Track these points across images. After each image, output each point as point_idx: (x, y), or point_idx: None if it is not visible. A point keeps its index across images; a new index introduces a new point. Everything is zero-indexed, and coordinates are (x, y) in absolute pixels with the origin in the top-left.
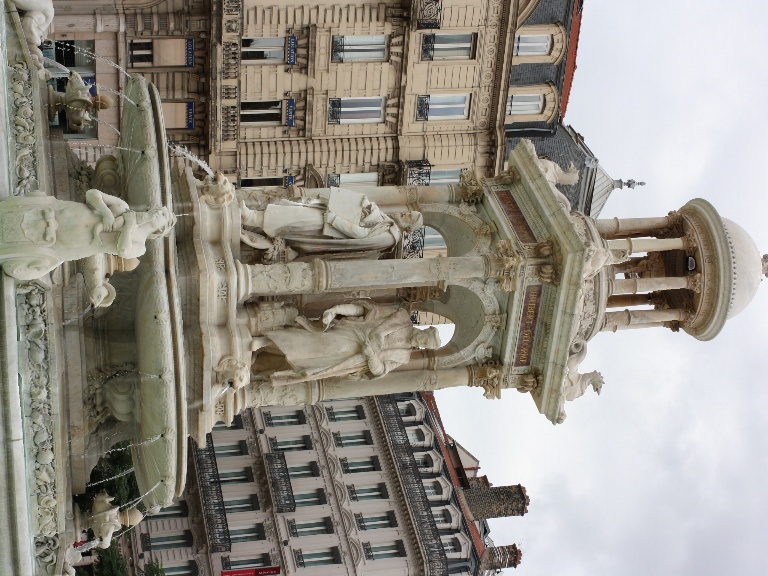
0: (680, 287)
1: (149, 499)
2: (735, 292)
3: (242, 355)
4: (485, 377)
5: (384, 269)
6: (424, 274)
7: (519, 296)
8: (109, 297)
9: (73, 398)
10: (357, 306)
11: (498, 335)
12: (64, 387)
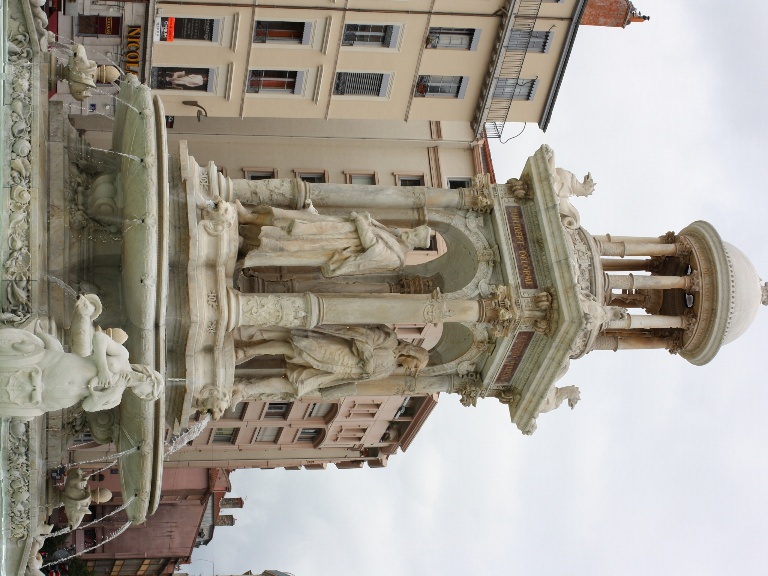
0: (669, 248)
1: None
2: (727, 251)
3: None
4: (495, 299)
5: None
6: (399, 189)
7: (501, 216)
8: None
9: (54, 177)
10: None
11: (497, 273)
12: (46, 162)
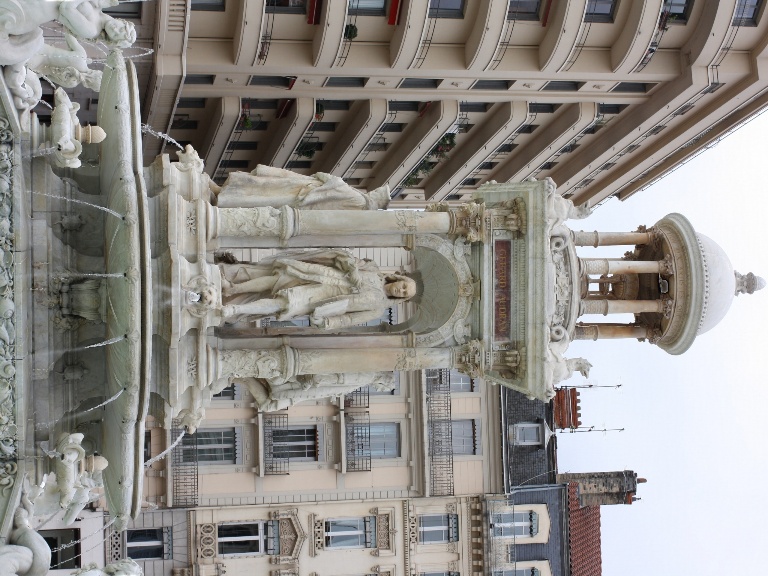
0: None
1: None
2: None
3: None
4: None
5: None
6: None
7: None
8: None
9: None
10: None
11: None
12: None
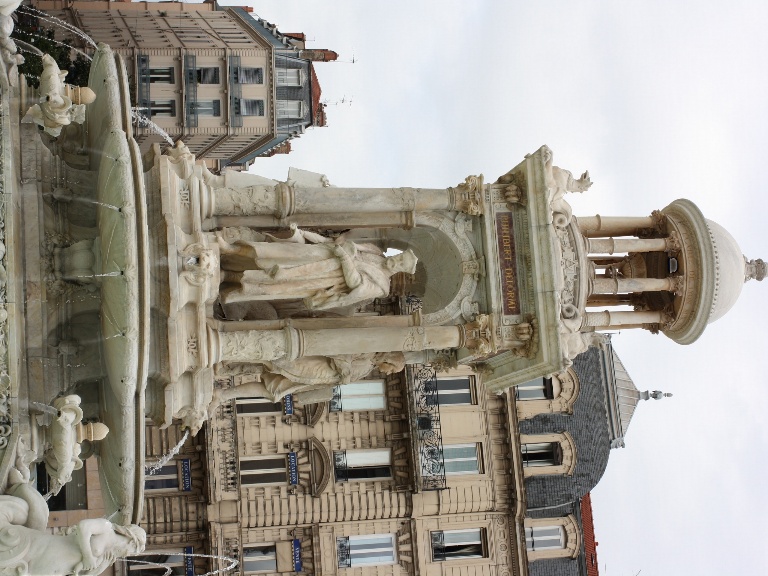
0: (659, 245)
1: (118, 453)
2: (717, 250)
3: (208, 247)
4: (476, 328)
5: (347, 189)
6: (388, 195)
7: (491, 226)
8: (65, 107)
9: (29, 244)
10: None
11: (481, 288)
12: (20, 227)
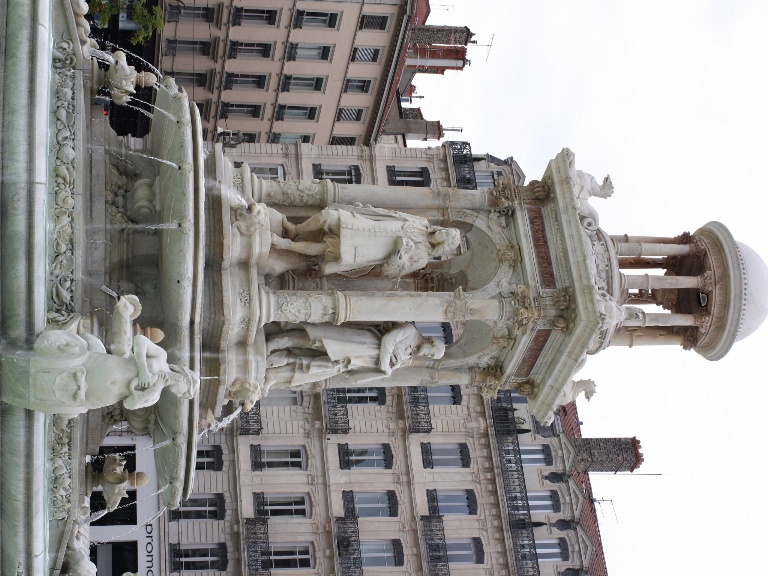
0: None
1: None
2: None
3: None
4: None
5: None
6: None
7: None
8: None
9: None
10: None
11: None
12: None
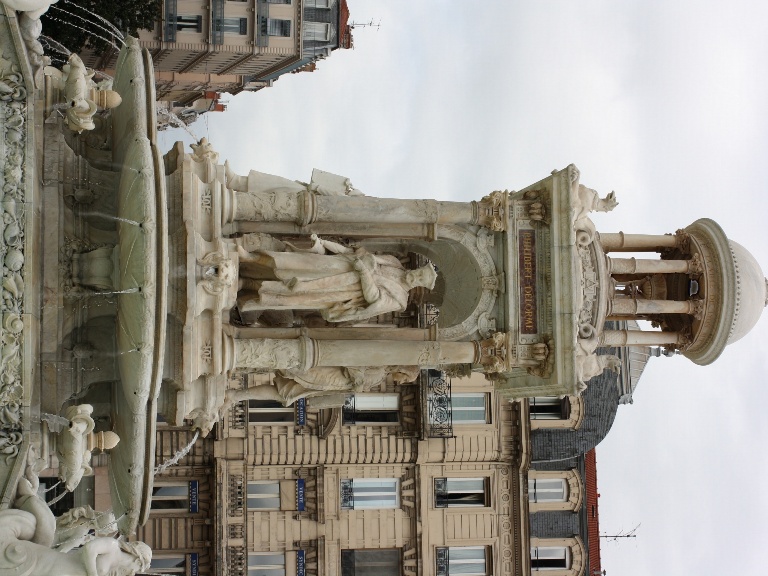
0: (681, 268)
1: (128, 459)
2: (739, 275)
3: (228, 256)
4: (492, 346)
5: (370, 199)
6: (411, 207)
7: (513, 243)
8: (90, 112)
9: (48, 250)
10: (346, 247)
11: (499, 304)
12: (39, 232)
